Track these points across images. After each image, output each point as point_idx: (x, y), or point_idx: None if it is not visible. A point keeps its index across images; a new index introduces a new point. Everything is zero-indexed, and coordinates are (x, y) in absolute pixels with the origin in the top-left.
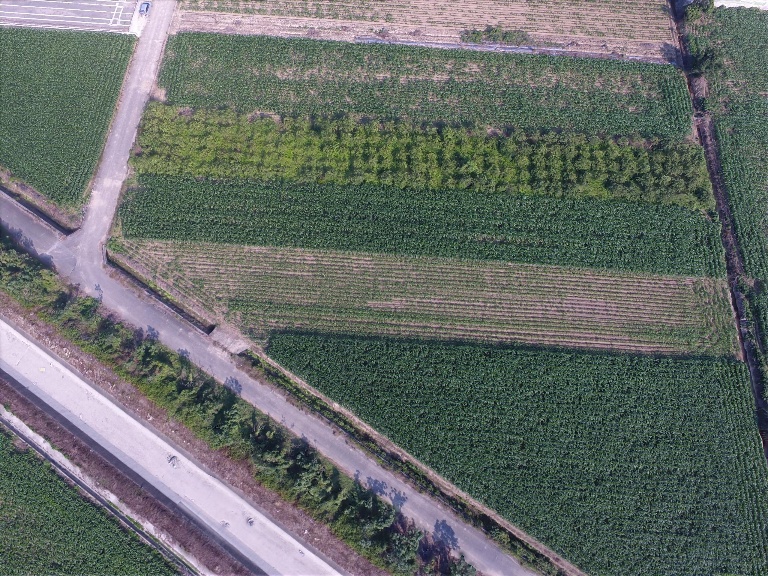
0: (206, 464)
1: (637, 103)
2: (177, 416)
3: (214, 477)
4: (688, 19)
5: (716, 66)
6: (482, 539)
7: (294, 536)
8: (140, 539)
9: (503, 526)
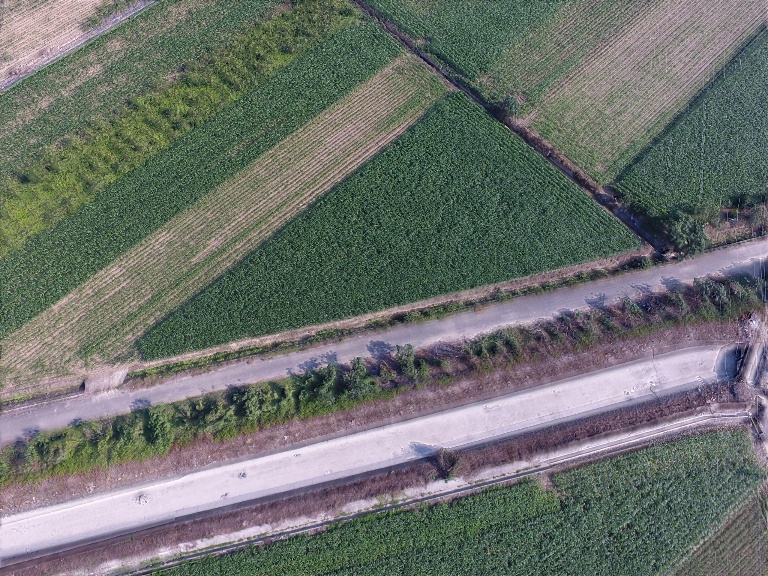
0: (170, 473)
1: None
2: (111, 465)
3: (185, 476)
4: None
5: None
6: (403, 328)
7: (281, 450)
8: (167, 572)
9: (410, 310)
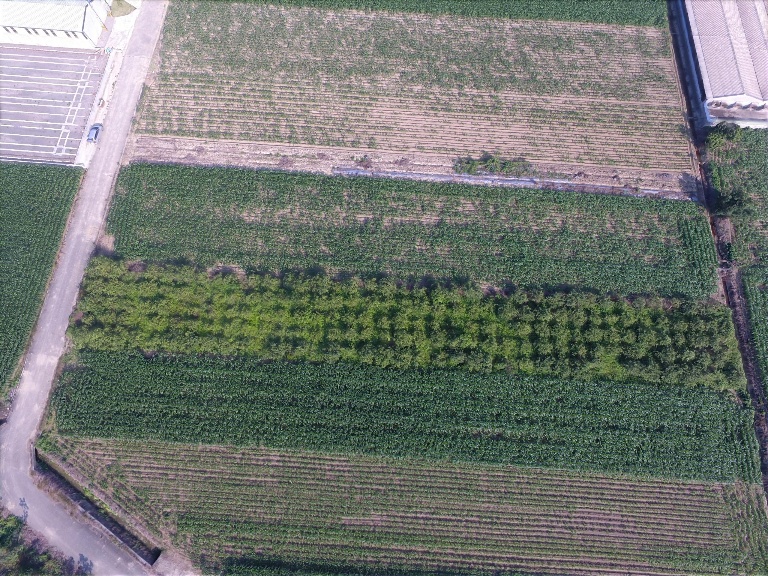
0: None
1: (654, 252)
2: None
3: None
4: (710, 147)
5: (745, 212)
6: None
7: None
8: None
9: None
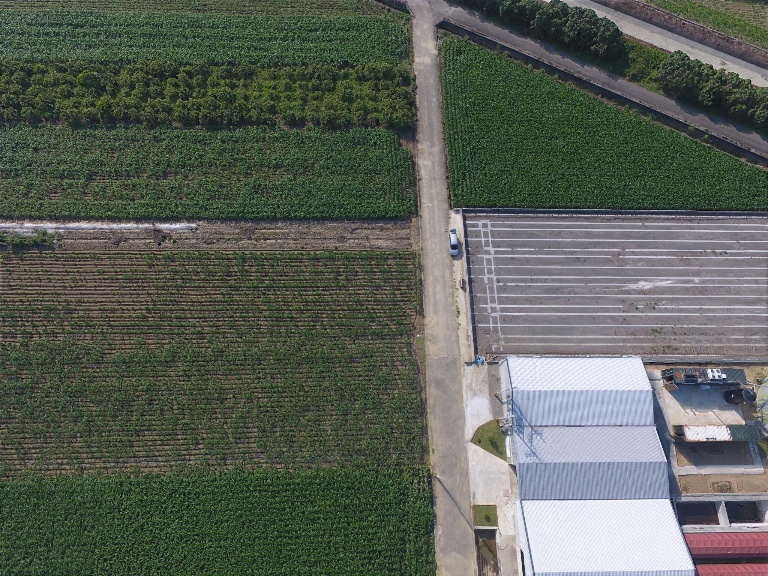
0: None
1: None
2: None
3: None
4: None
5: None
6: None
7: None
8: None
9: None
